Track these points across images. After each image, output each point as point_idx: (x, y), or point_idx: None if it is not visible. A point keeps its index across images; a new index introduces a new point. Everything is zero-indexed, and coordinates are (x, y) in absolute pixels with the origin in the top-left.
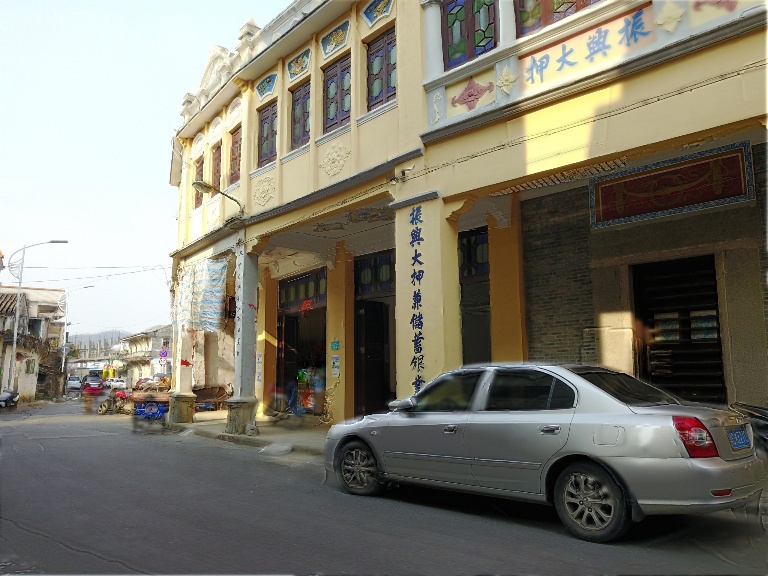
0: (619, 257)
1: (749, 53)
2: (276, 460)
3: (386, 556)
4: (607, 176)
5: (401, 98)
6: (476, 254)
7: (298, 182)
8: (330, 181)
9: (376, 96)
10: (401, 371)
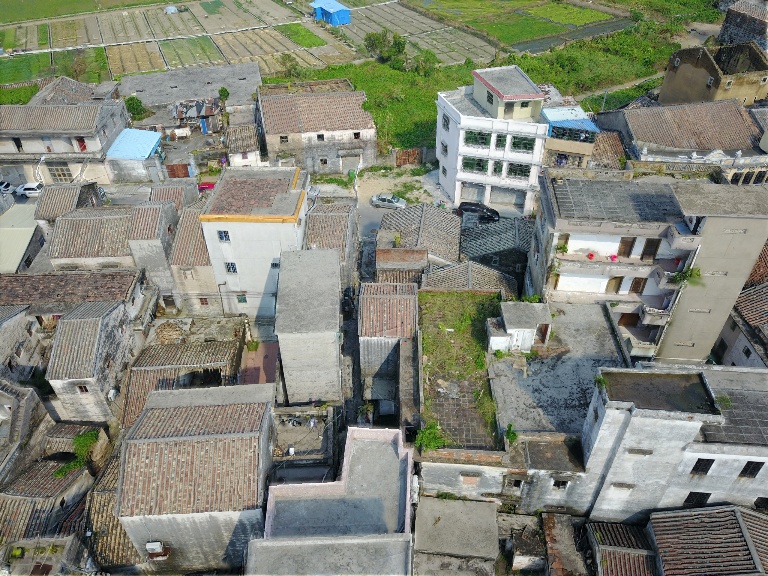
0: None
1: None
2: None
3: None
4: None
5: None
6: None
7: None
8: None
9: (767, 179)
10: None
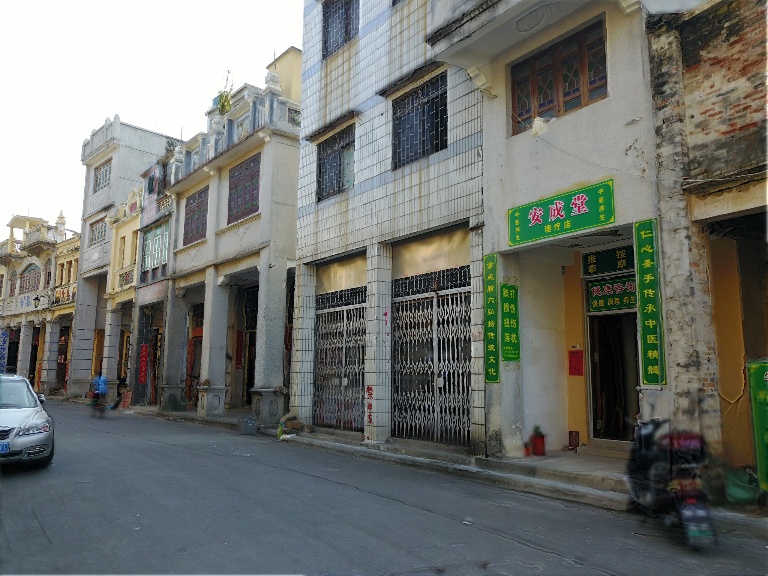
0: None
1: None
2: None
3: None
4: None
5: None
6: None
7: None
8: None
9: None
10: None
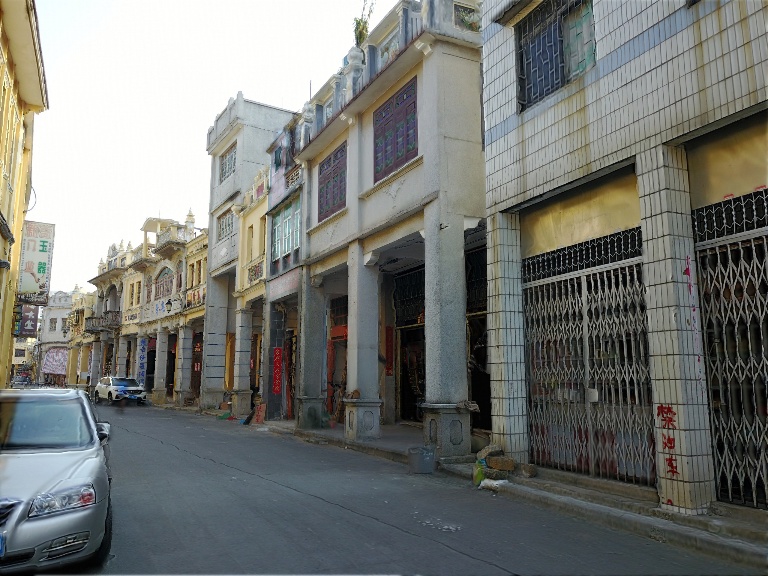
0: None
1: None
2: None
3: (227, 501)
4: None
5: None
6: None
7: None
8: None
9: None
10: None
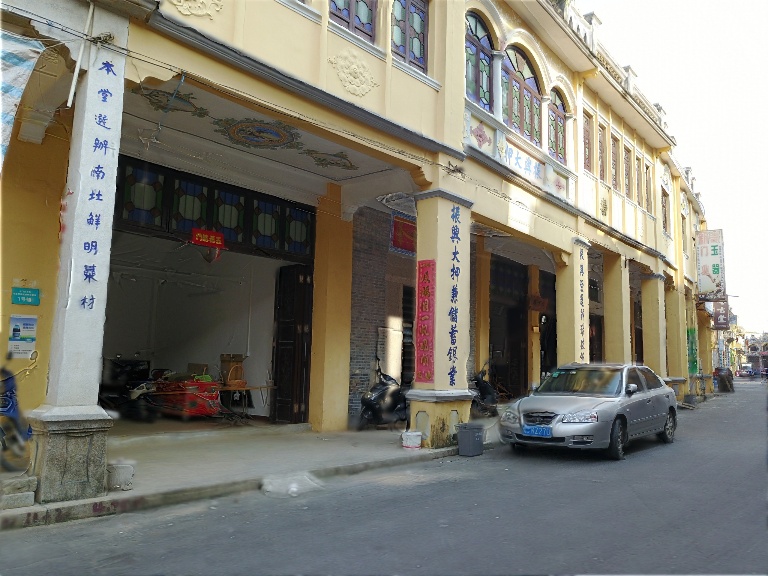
0: (401, 277)
1: (564, 220)
2: (398, 485)
3: (757, 455)
4: (401, 214)
5: (449, 90)
6: (290, 229)
7: (286, 48)
8: (348, 97)
9: None
10: (441, 361)
